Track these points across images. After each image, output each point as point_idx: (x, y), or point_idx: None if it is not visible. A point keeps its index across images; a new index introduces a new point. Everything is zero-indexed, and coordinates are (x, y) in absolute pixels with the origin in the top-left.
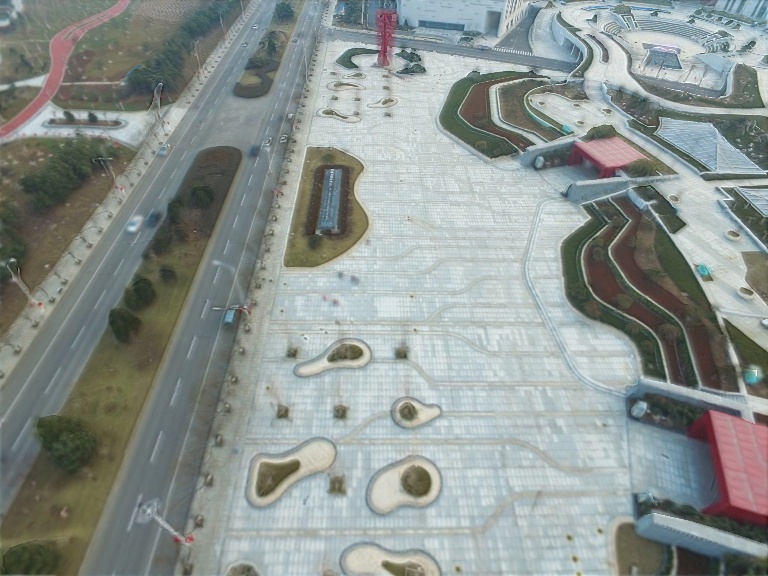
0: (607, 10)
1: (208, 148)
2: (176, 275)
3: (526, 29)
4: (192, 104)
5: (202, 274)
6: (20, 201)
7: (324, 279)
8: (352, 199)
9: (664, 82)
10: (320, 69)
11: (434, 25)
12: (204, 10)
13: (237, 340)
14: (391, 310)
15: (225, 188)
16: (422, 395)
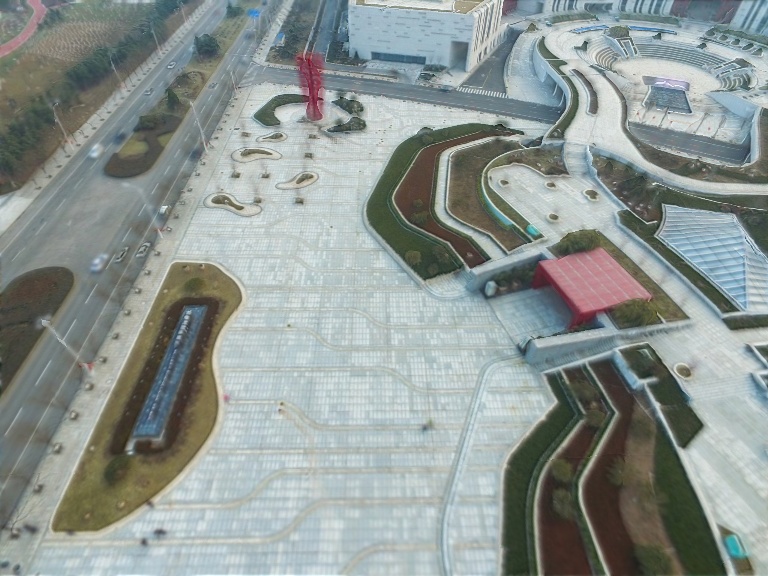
0: (600, 32)
1: (28, 272)
2: None
3: (502, 59)
4: (43, 190)
5: None
6: None
7: (106, 561)
8: (205, 368)
9: (669, 134)
10: (231, 128)
11: (390, 57)
12: (112, 45)
13: None
14: None
15: (22, 352)
16: None
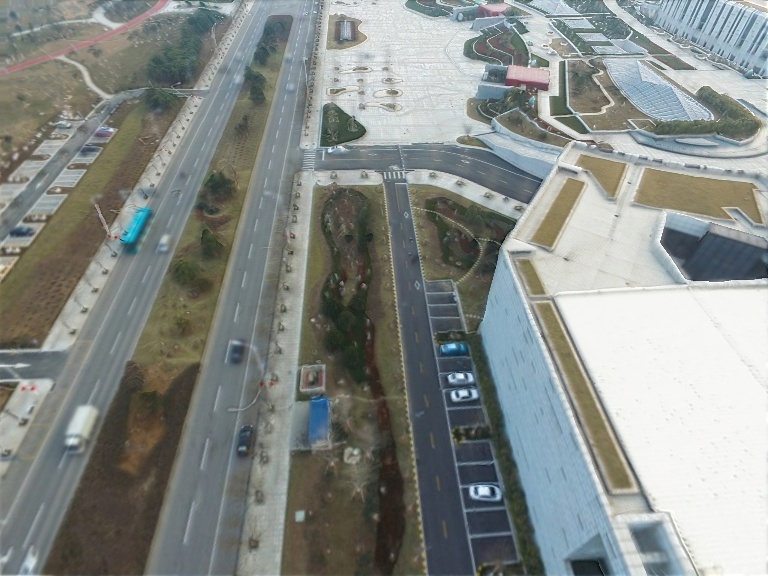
0: None
1: (273, 15)
2: (276, 50)
3: None
4: (255, 1)
5: (288, 52)
6: (188, 28)
7: (347, 52)
8: (357, 31)
9: None
10: None
11: None
12: None
13: (311, 66)
14: (380, 60)
15: (289, 28)
16: (395, 78)
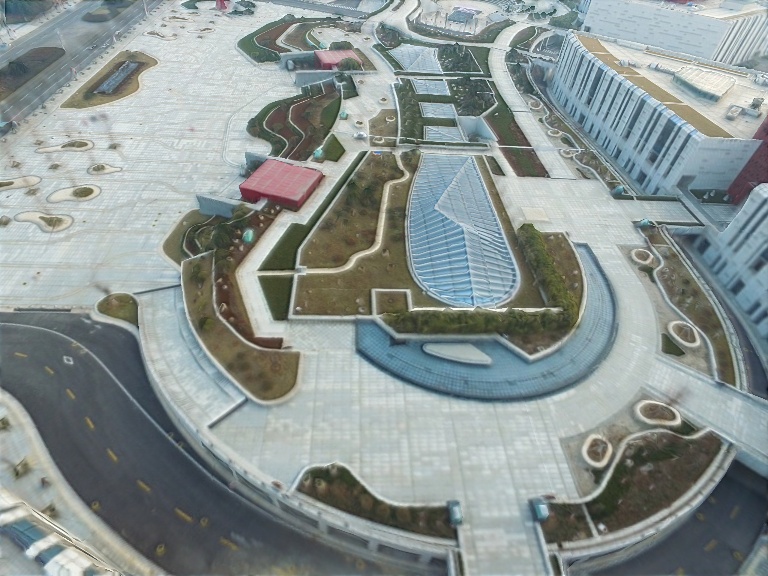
0: None
1: (40, 47)
2: None
3: None
4: (44, 24)
5: None
6: None
7: (84, 114)
8: (134, 79)
9: (448, 31)
10: (165, 8)
11: None
12: None
13: None
14: (121, 129)
15: (40, 68)
16: (114, 163)
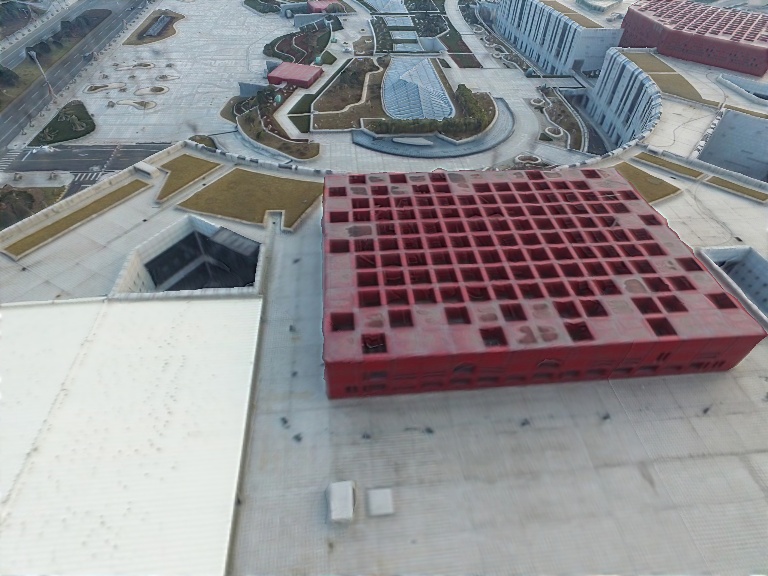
0: None
1: (91, 9)
2: (63, 46)
3: None
4: None
5: (77, 47)
6: None
7: (141, 48)
8: (171, 27)
9: None
10: None
11: None
12: None
13: (90, 62)
14: (171, 56)
15: (97, 22)
16: (173, 75)
